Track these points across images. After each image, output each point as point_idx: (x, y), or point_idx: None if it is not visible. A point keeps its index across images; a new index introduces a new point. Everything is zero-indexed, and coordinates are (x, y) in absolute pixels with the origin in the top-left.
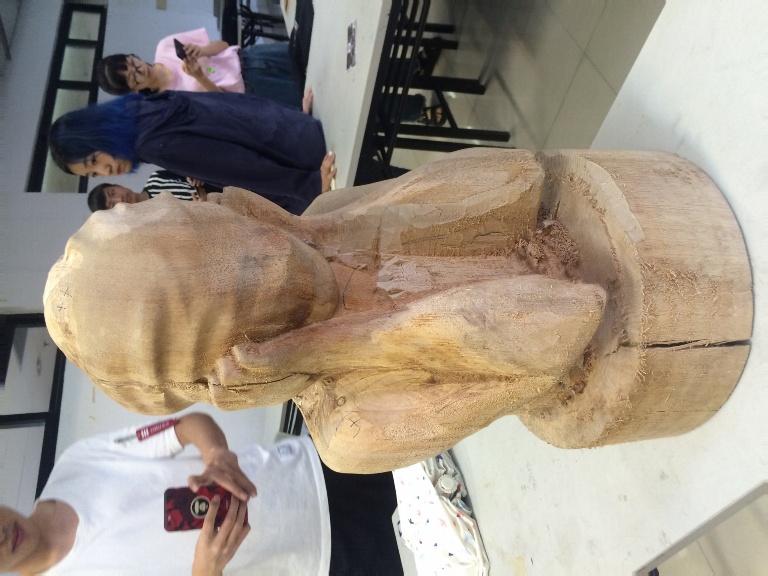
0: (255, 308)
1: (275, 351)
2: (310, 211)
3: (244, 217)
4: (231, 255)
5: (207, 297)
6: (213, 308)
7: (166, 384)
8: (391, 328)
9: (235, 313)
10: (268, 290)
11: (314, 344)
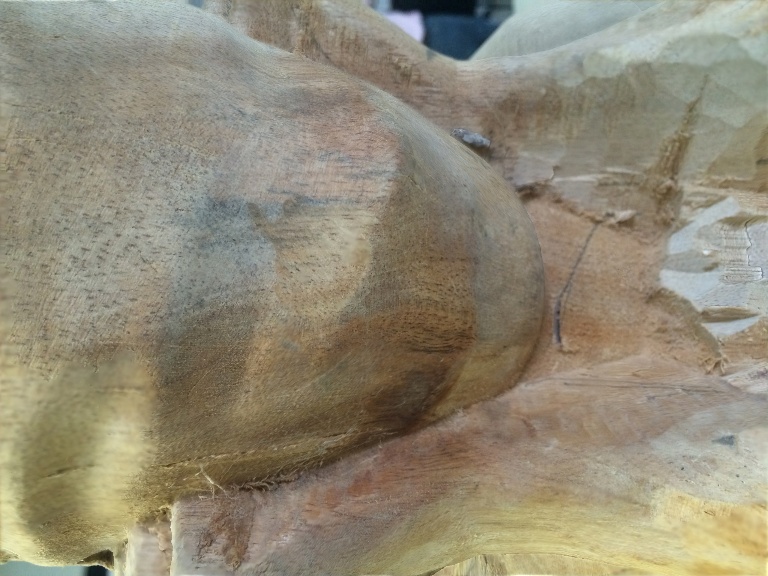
0: (242, 392)
1: (303, 550)
2: (489, 52)
3: (271, 50)
4: (152, 193)
5: (35, 363)
6: (65, 401)
7: (2, 556)
8: (736, 495)
9: (157, 417)
10: (293, 330)
11: (449, 504)
